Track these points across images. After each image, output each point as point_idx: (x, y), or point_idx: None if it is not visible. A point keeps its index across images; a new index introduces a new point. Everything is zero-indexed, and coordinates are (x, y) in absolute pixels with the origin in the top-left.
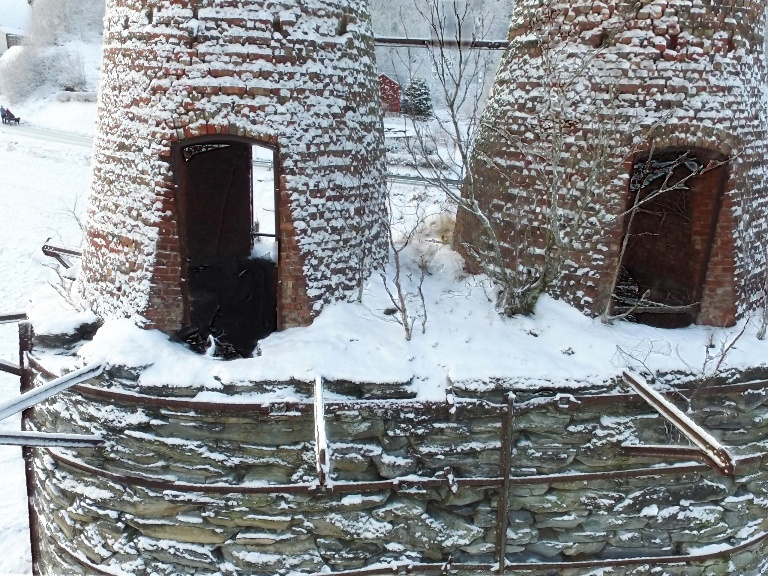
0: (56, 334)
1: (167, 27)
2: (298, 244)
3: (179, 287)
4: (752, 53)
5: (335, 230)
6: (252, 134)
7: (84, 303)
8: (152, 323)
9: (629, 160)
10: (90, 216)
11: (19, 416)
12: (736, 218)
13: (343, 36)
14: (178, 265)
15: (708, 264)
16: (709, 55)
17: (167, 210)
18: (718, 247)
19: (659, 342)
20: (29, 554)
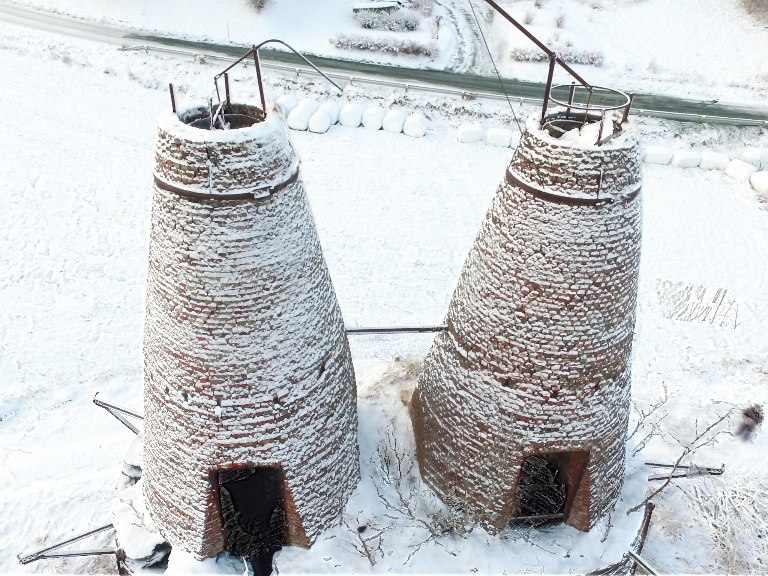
0: (142, 558)
1: (199, 408)
2: (298, 513)
3: (220, 532)
4: (615, 381)
5: (322, 493)
6: (264, 465)
7: (155, 529)
8: (205, 556)
9: (521, 459)
10: (151, 477)
11: (55, 383)
12: (593, 480)
13: (323, 375)
14: (219, 523)
15: (574, 498)
16: (580, 399)
17: (210, 503)
18: (581, 492)
19: (529, 574)
20: (95, 521)
